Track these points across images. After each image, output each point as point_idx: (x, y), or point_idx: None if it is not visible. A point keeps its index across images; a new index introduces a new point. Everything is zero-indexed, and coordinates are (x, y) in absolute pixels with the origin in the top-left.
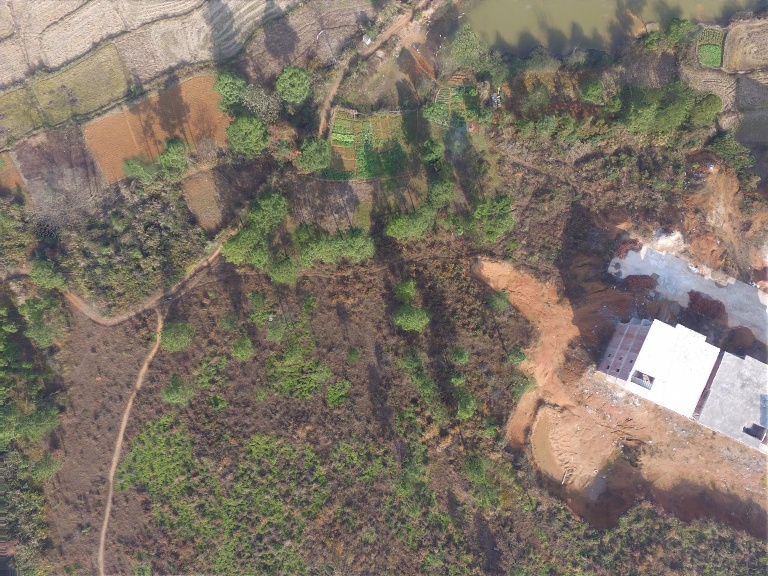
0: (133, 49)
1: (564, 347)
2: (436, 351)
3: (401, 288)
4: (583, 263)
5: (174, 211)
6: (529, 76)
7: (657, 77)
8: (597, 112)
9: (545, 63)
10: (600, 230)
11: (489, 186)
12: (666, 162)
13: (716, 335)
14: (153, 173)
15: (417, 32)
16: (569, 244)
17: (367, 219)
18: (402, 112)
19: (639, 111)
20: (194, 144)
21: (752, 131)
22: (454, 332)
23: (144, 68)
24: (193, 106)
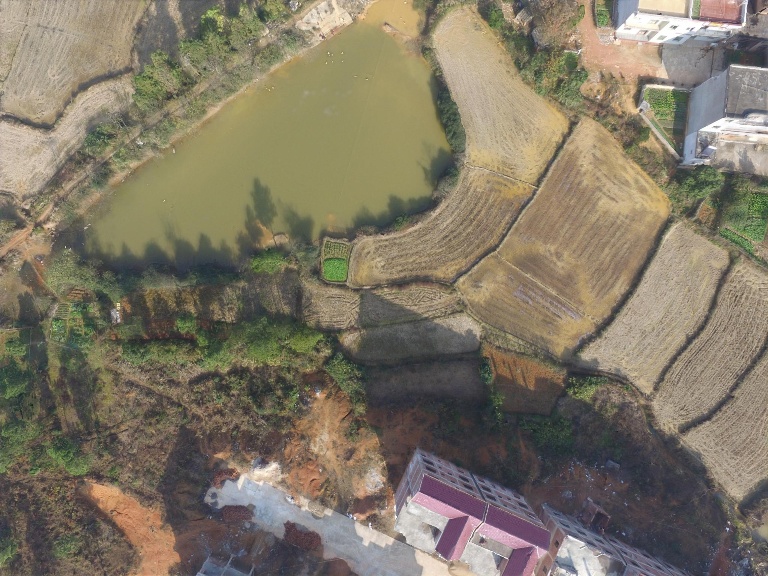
0: None
1: (165, 573)
2: (38, 575)
3: (5, 511)
4: (183, 490)
5: None
6: (149, 291)
7: (280, 292)
8: (216, 329)
9: (155, 284)
10: (201, 457)
11: (103, 405)
12: (277, 384)
13: (311, 567)
14: None
15: (41, 244)
16: (173, 469)
17: None
18: (17, 329)
19: None
20: None
21: (374, 348)
22: (55, 557)
23: None
24: None
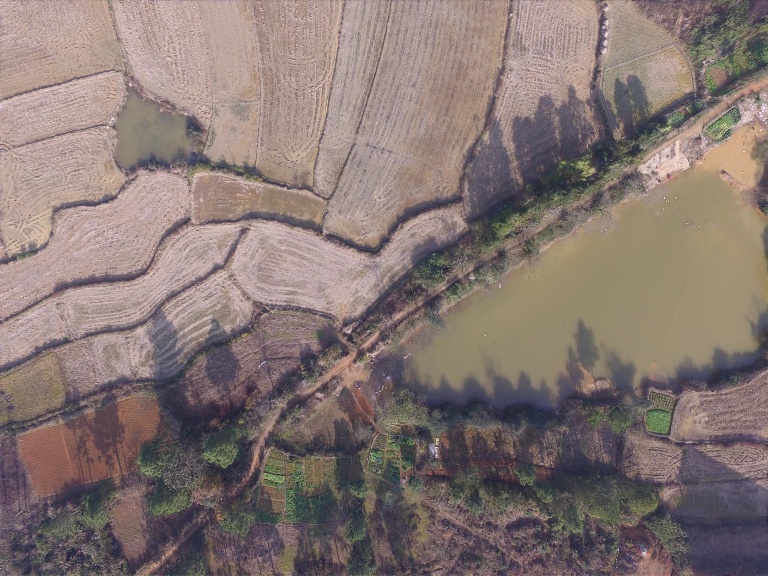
0: (74, 360)
1: None
2: None
3: None
4: None
5: (98, 540)
6: (469, 429)
7: (601, 440)
8: (535, 473)
9: (485, 427)
10: None
11: (417, 541)
12: (599, 538)
13: None
14: (80, 503)
15: (360, 371)
16: None
17: (291, 565)
18: (336, 457)
19: (567, 523)
20: (126, 467)
21: (693, 506)
22: None
23: (84, 381)
24: (128, 427)
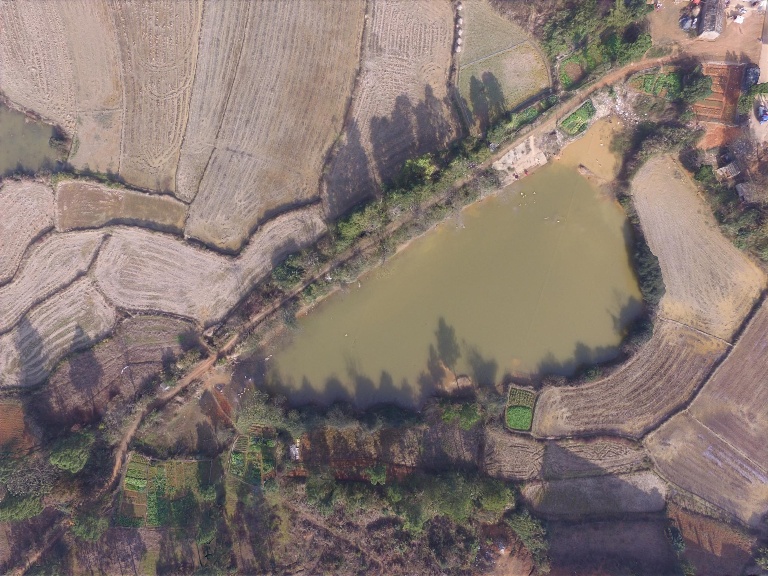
0: None
1: None
2: None
3: None
4: None
5: None
6: (330, 429)
7: (462, 438)
8: (396, 472)
9: (341, 426)
10: None
11: (279, 543)
12: (459, 536)
13: None
14: None
15: (222, 373)
16: None
17: (153, 569)
18: (197, 460)
19: None
20: None
21: (556, 502)
22: None
23: None
24: None
